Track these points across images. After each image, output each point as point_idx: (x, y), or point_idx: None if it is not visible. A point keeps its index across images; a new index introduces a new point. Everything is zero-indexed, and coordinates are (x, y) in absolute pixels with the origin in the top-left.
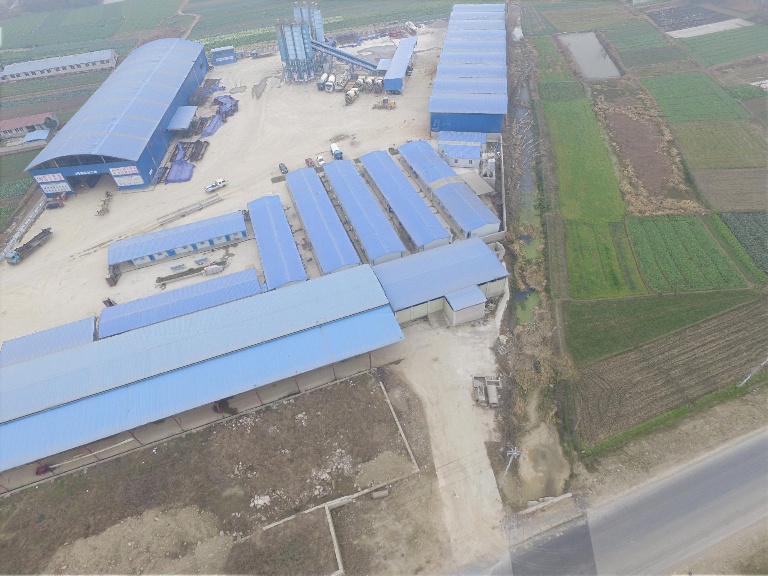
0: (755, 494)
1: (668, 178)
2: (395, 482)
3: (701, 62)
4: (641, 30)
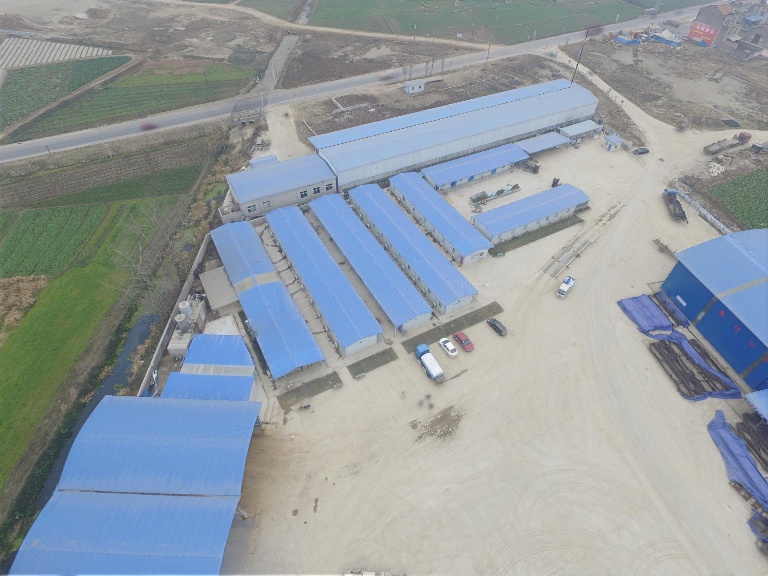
0: None
1: None
2: None
3: None
4: None
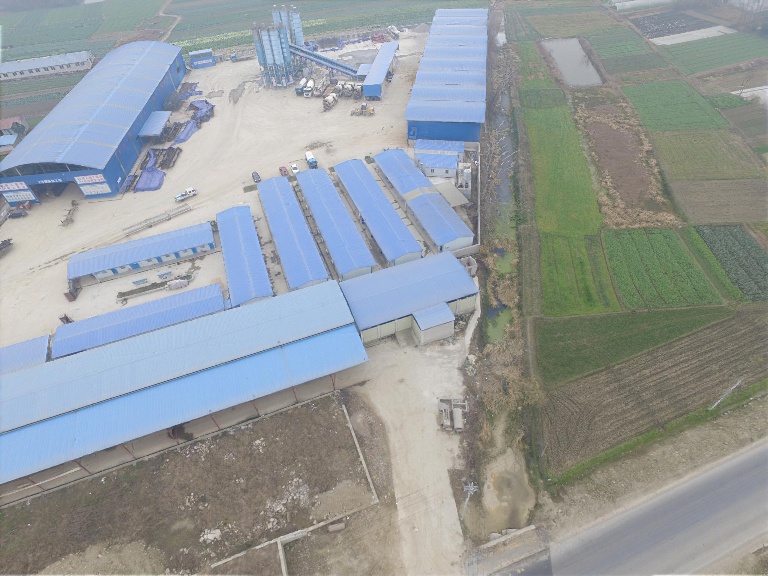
0: (723, 526)
1: (646, 189)
2: (353, 514)
3: (683, 70)
4: (624, 37)
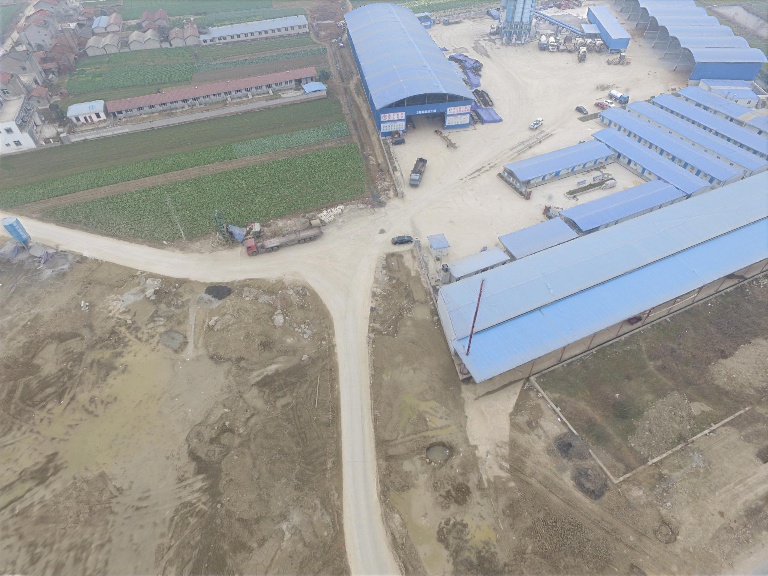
0: None
1: None
2: None
3: None
4: None
